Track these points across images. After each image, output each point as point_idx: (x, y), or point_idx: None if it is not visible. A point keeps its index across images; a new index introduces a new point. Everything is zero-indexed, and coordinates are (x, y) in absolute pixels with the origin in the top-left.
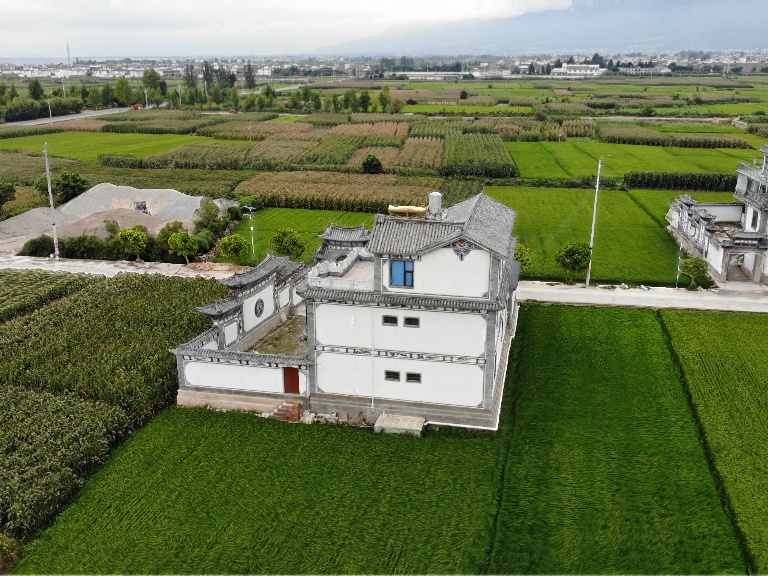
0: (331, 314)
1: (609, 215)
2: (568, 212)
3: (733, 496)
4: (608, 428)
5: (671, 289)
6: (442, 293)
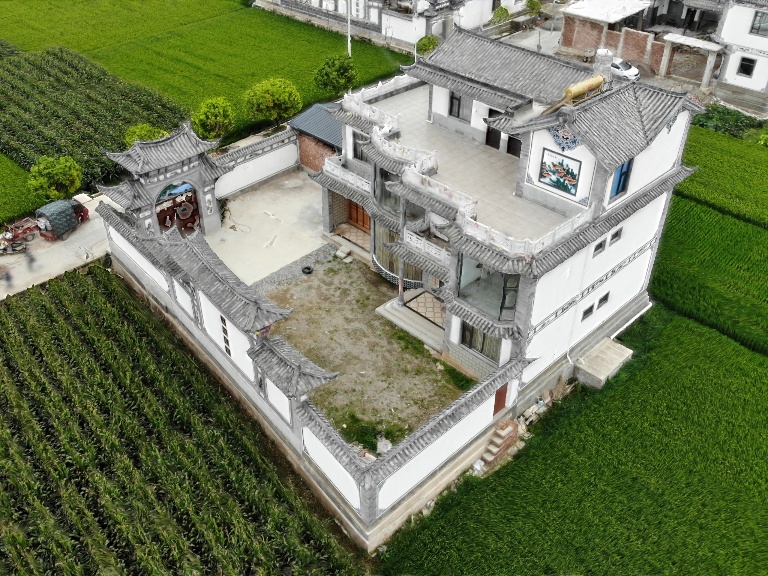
0: (550, 280)
1: (168, 5)
2: (119, 13)
3: None
4: (684, 245)
5: None
6: (645, 184)
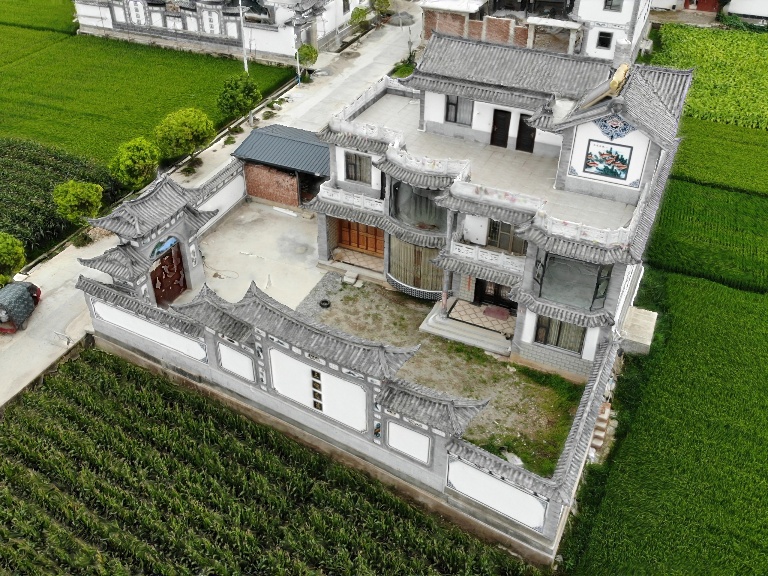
0: None
1: None
2: None
3: (751, 189)
4: None
5: (298, 89)
6: None
